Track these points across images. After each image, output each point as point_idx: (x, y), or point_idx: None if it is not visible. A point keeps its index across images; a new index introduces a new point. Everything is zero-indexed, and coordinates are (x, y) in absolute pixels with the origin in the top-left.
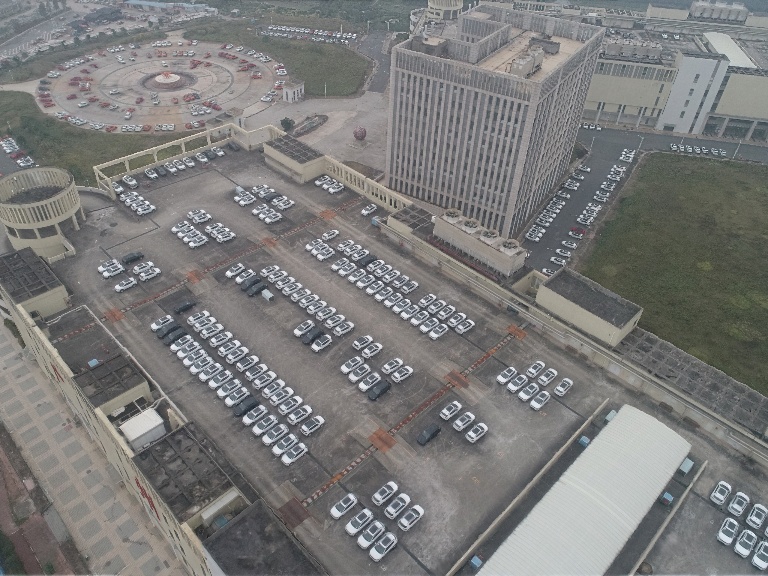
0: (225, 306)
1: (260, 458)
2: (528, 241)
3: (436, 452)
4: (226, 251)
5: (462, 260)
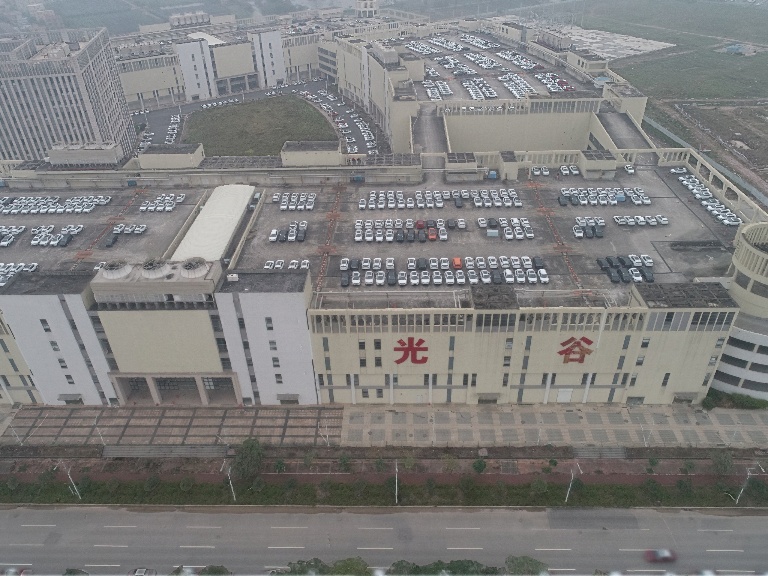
0: None
1: None
2: None
3: (121, 246)
4: None
5: (81, 169)
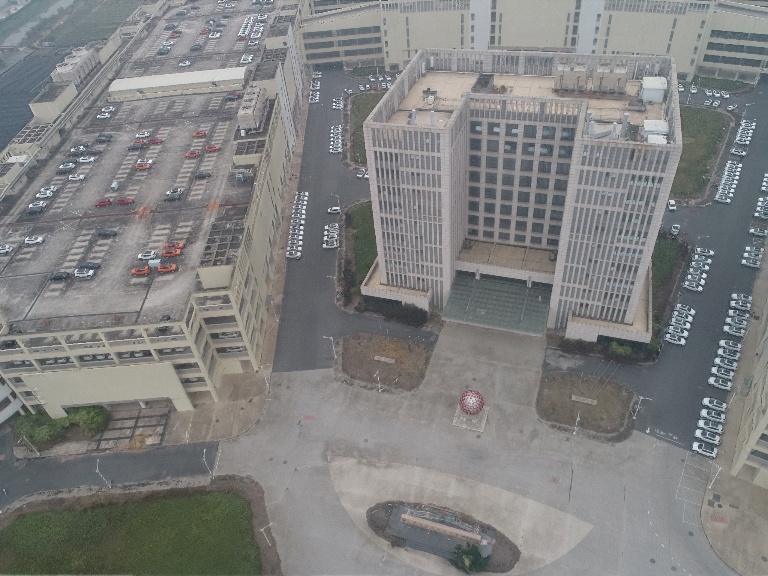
0: None
1: None
2: None
3: None
4: None
5: None
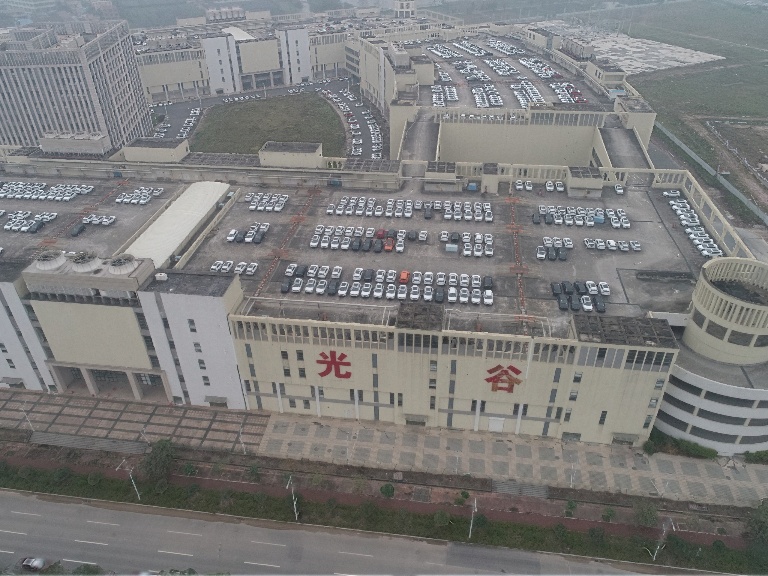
0: None
1: None
2: None
3: (86, 236)
4: None
5: (70, 158)
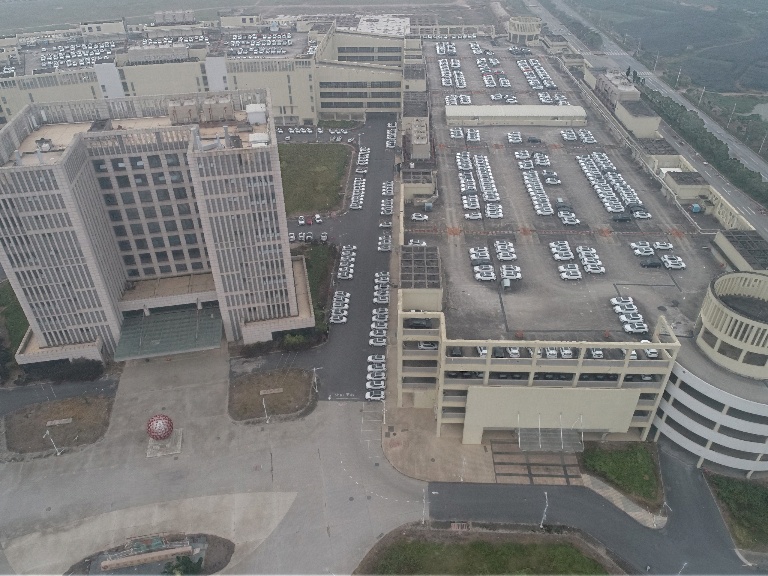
0: (592, 211)
1: (615, 161)
2: None
3: None
4: (566, 240)
5: None
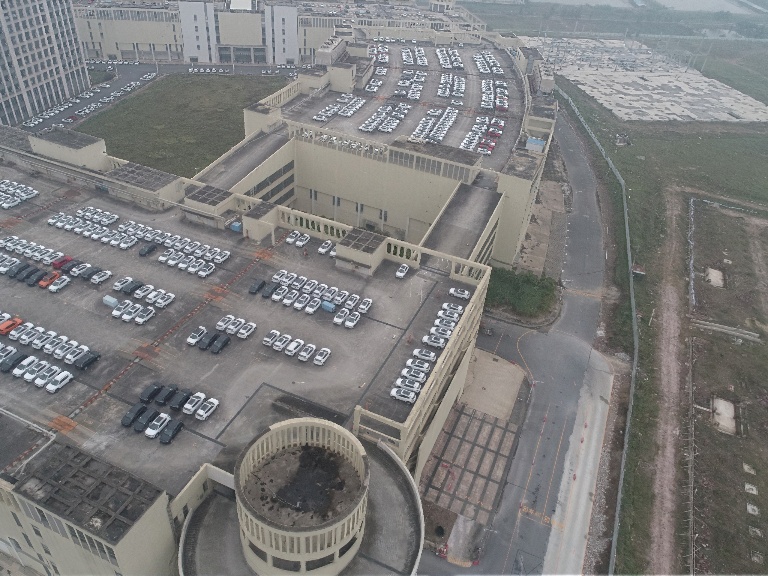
0: None
1: None
2: (25, 127)
3: None
4: None
5: None
